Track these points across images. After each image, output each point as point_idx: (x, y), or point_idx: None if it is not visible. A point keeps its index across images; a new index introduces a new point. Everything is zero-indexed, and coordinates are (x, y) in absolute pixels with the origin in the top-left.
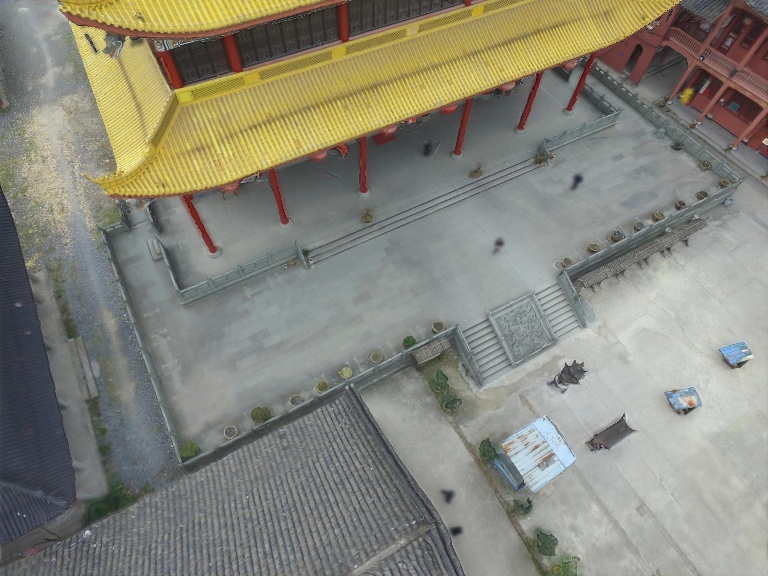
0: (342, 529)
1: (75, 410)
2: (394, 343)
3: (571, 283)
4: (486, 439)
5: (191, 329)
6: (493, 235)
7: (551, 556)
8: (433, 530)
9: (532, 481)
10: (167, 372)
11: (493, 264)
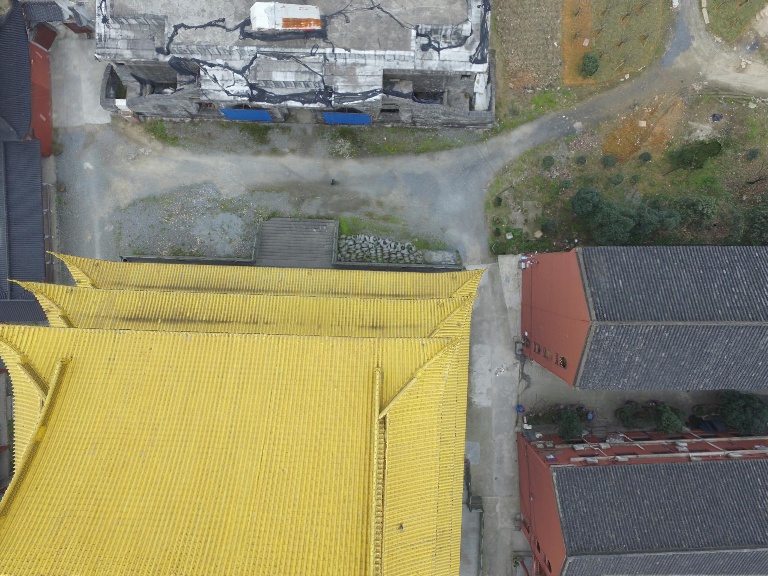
0: None
1: None
2: None
3: None
4: None
5: None
6: None
7: None
8: None
9: None
10: None
11: None
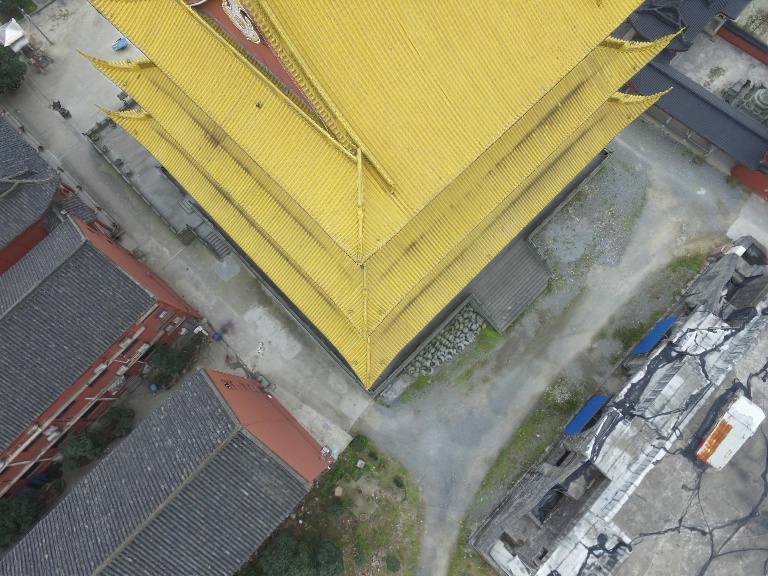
0: None
1: None
2: None
3: None
4: None
5: None
6: None
7: None
8: None
9: None
10: None
11: None
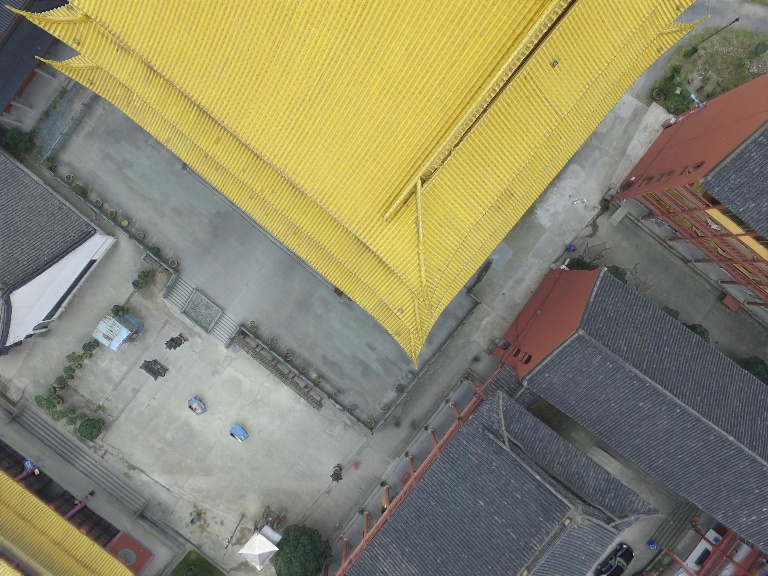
0: (6, 256)
1: (54, 85)
2: (156, 242)
3: (235, 332)
4: (123, 307)
5: (114, 122)
6: (259, 276)
7: (95, 352)
8: (2, 292)
9: (96, 333)
10: (86, 124)
11: (236, 282)
